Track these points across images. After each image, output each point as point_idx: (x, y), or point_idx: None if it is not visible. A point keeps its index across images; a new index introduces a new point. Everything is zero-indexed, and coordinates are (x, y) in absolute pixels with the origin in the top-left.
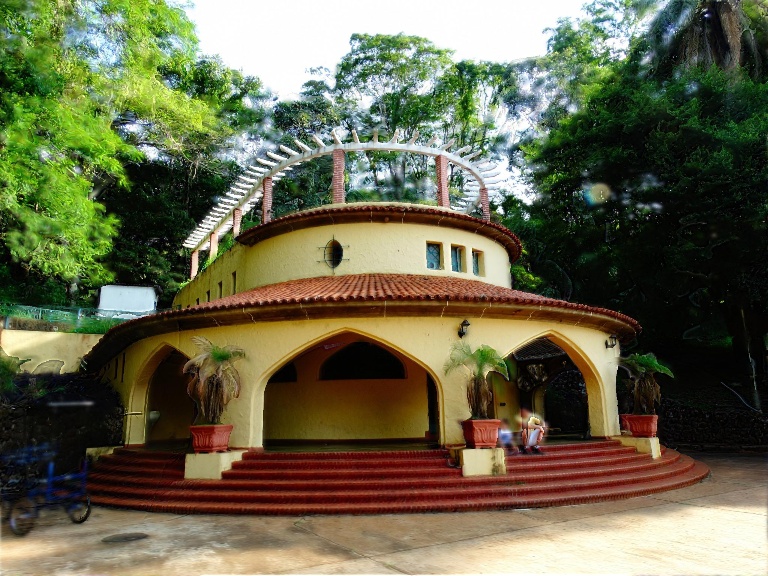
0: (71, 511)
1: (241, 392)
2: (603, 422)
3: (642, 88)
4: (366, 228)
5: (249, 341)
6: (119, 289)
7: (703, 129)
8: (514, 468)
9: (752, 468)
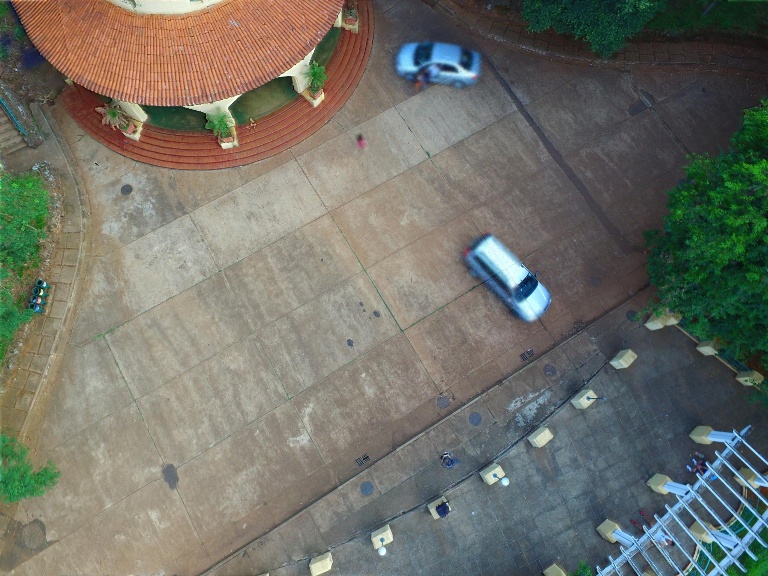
0: (96, 151)
1: None
2: None
3: None
4: None
5: None
6: None
7: None
8: None
9: (381, 83)
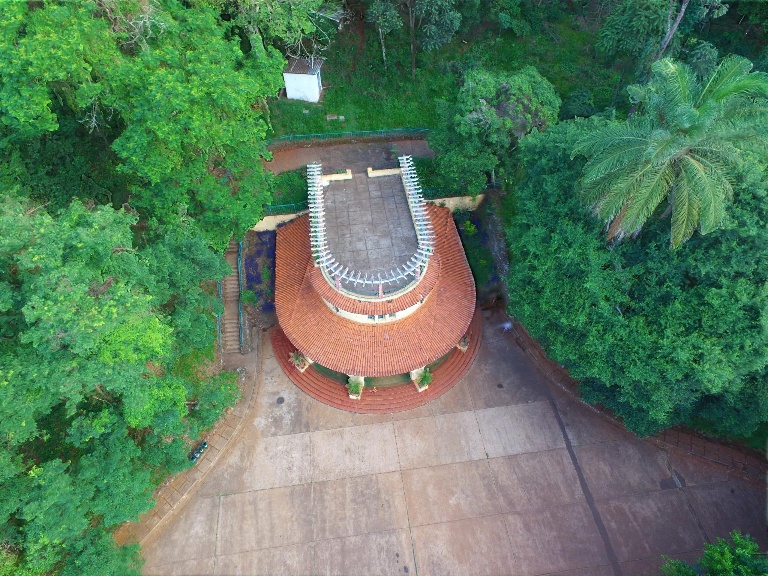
0: (275, 369)
1: None
2: None
3: (534, 232)
4: None
5: None
6: (293, 76)
7: (542, 279)
8: (363, 399)
9: (470, 390)
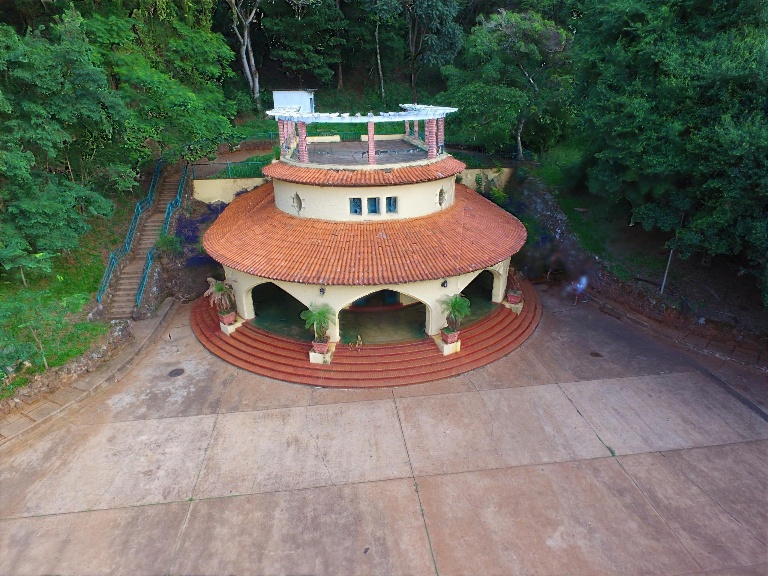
0: None
1: (240, 296)
2: (429, 328)
3: None
4: (312, 189)
5: (238, 275)
6: (284, 94)
7: (656, 52)
8: (335, 363)
9: (541, 359)
